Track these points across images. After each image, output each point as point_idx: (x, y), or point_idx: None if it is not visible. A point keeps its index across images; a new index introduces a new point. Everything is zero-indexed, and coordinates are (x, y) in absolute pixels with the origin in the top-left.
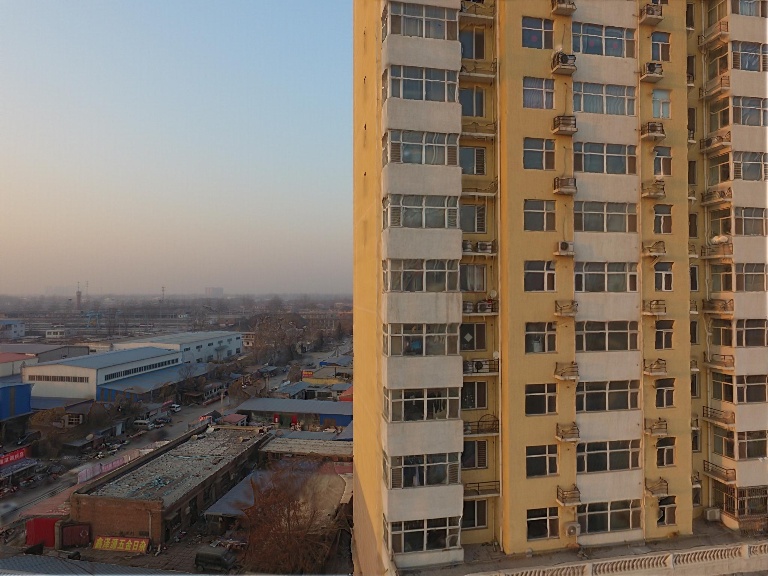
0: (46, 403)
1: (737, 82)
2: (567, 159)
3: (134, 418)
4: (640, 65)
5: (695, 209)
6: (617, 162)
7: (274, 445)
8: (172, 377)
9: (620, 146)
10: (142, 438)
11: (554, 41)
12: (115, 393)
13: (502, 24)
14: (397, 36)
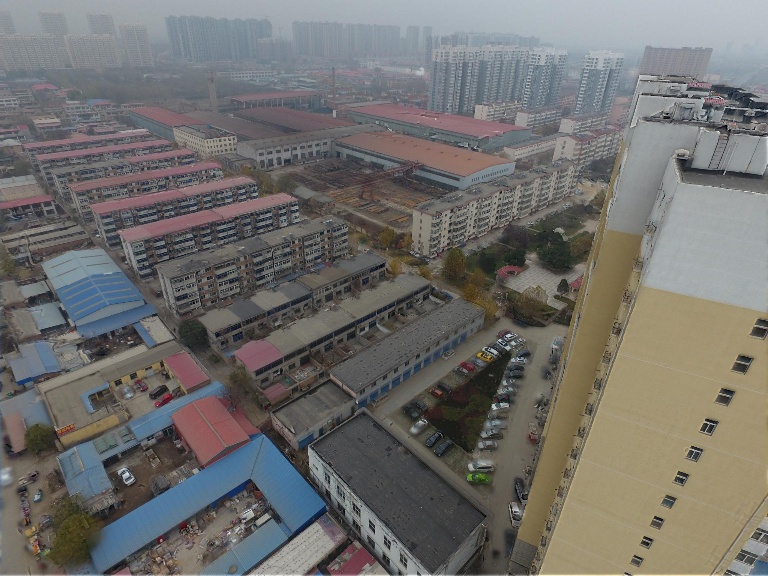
0: None
1: None
2: None
3: None
4: None
5: None
6: None
7: None
8: None
9: None
10: None
11: None
12: None
13: None
14: None
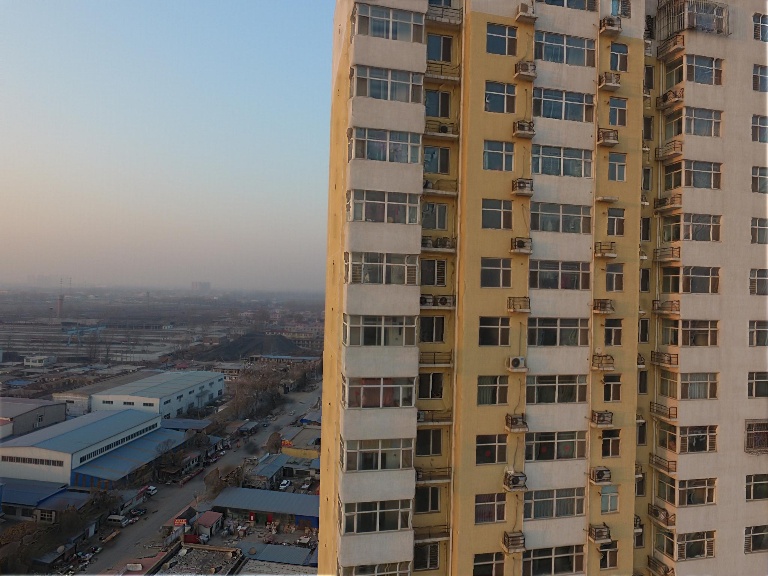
0: (18, 493)
1: (683, 467)
2: (516, 570)
3: (108, 513)
4: (590, 466)
5: (641, 571)
6: (565, 562)
7: (246, 575)
8: (149, 451)
9: (568, 548)
10: (115, 542)
11: (507, 454)
12: (90, 479)
13: (457, 442)
14: (352, 474)
